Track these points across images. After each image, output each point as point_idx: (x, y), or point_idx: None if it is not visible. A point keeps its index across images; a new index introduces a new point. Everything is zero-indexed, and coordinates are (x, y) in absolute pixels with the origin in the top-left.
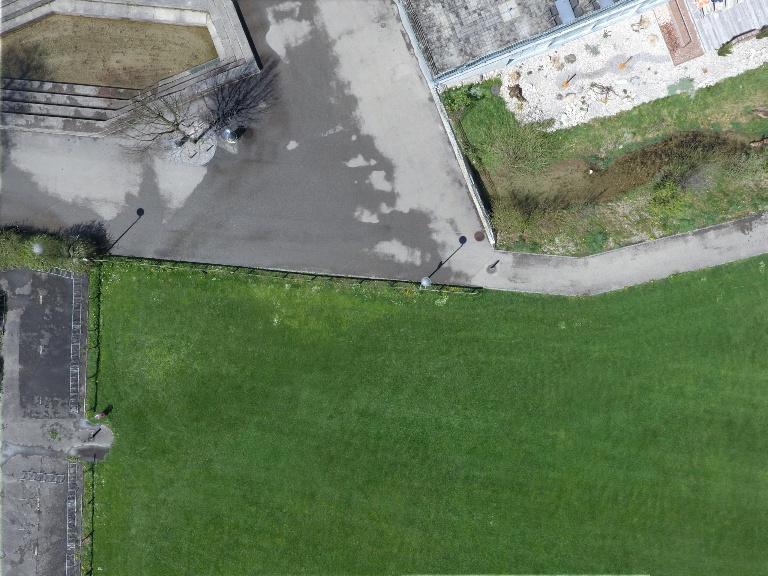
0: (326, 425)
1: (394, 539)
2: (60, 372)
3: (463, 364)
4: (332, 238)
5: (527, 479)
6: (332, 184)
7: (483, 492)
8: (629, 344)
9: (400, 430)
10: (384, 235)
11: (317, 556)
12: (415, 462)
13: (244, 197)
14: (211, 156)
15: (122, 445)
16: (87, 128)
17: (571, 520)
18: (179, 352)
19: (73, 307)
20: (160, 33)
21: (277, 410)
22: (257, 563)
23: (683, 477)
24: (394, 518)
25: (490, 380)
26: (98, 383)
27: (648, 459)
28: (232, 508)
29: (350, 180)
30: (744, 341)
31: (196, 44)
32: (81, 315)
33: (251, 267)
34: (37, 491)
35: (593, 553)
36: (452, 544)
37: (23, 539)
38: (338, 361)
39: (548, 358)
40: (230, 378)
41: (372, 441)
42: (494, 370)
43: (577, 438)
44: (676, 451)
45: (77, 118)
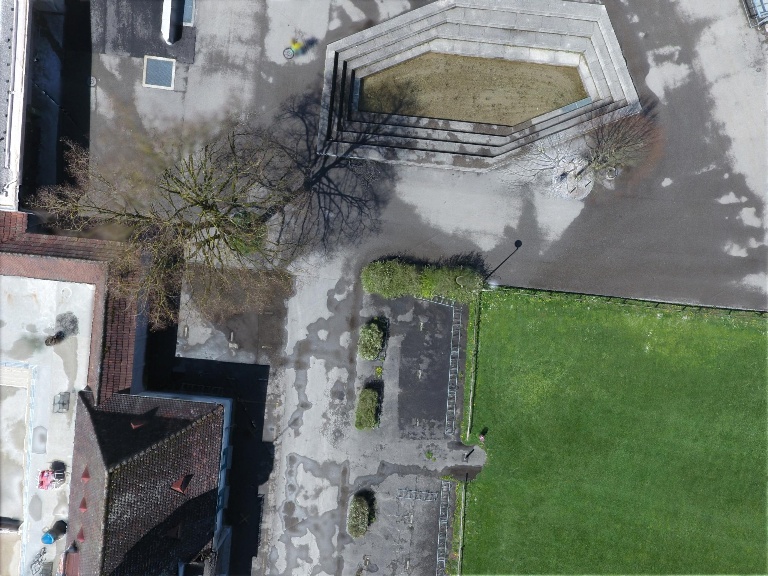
0: (691, 447)
1: (751, 555)
2: (437, 395)
3: None
4: (702, 271)
5: None
6: (704, 219)
7: None
8: None
9: (762, 452)
10: (752, 268)
11: (677, 570)
12: None
13: (619, 231)
14: (588, 191)
15: (495, 465)
16: (476, 164)
17: None
18: (553, 377)
19: (452, 334)
20: (529, 72)
21: (646, 433)
22: None
23: None
24: (752, 535)
25: None
26: (475, 406)
27: None
28: (598, 525)
29: (721, 216)
30: None
31: (562, 83)
32: (459, 341)
33: (623, 297)
34: (411, 508)
35: None
36: None
37: (396, 554)
38: (706, 387)
39: None
40: (601, 402)
41: (735, 462)
42: None
43: None
44: None
45: (466, 154)
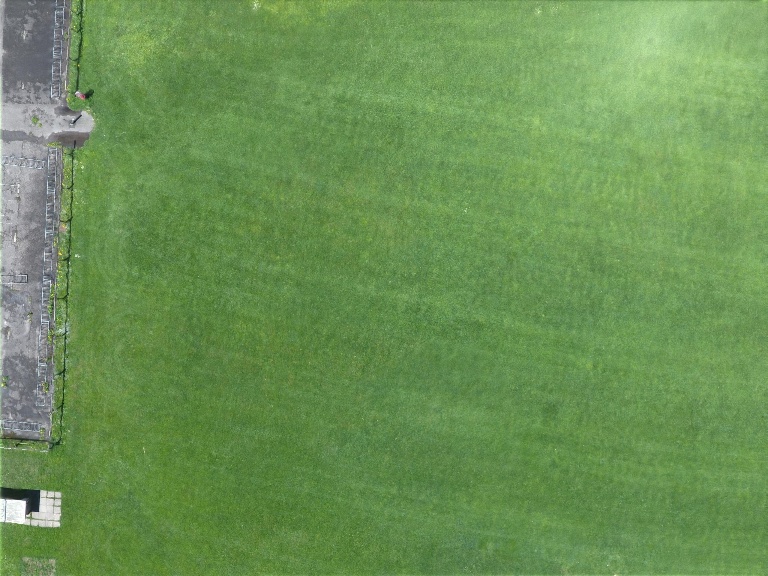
0: (303, 111)
1: (369, 227)
2: (43, 57)
3: (440, 49)
4: None
5: (502, 166)
6: None
7: (458, 179)
8: (605, 28)
9: (376, 115)
10: None
11: (292, 244)
12: (391, 148)
13: None
14: None
15: (102, 130)
16: None
17: (545, 208)
18: (160, 37)
19: None
20: None
21: (255, 95)
22: (233, 251)
23: (658, 164)
24: (369, 205)
25: (467, 65)
26: (80, 68)
27: (623, 145)
28: (209, 194)
29: None
30: (720, 27)
31: None
32: (65, 0)
33: None
34: (17, 177)
35: (567, 240)
36: (426, 232)
37: (2, 225)
38: (316, 46)
39: (524, 42)
40: (210, 63)
41: (349, 127)
42: (471, 55)
43: (552, 123)
44: (651, 138)
45: None
